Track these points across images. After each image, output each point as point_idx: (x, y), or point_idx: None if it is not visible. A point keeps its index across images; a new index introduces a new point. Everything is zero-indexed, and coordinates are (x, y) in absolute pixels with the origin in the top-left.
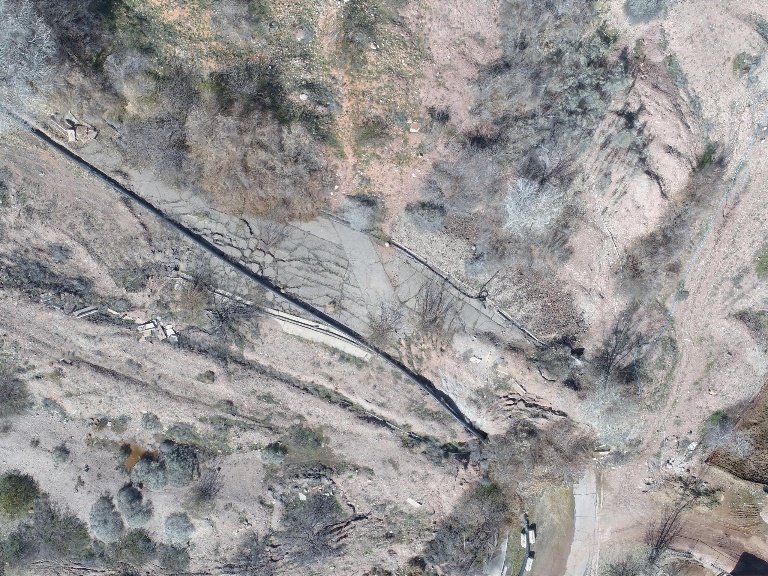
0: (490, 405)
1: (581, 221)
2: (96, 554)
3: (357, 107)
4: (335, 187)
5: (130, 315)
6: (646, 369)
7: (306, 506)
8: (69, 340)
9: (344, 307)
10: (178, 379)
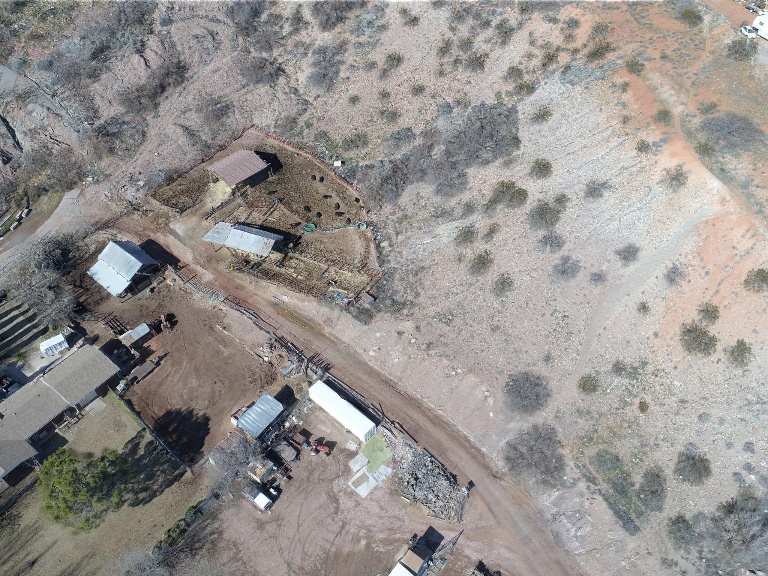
0: (32, 136)
1: (108, 71)
2: None
3: (35, 30)
4: (12, 54)
5: None
6: (122, 136)
7: None
8: None
9: None
10: None
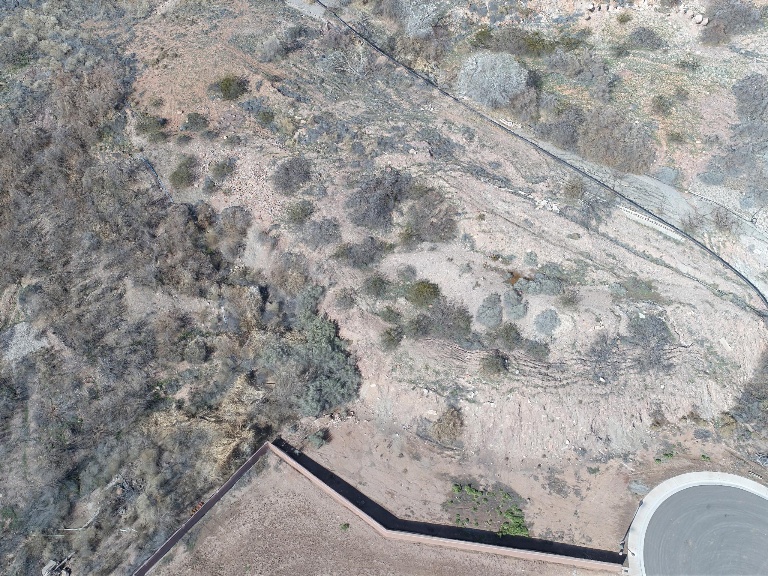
0: None
1: None
2: (473, 342)
3: (667, 128)
4: (654, 161)
5: (532, 195)
6: None
7: (645, 323)
8: (491, 203)
9: (664, 213)
10: (555, 235)
